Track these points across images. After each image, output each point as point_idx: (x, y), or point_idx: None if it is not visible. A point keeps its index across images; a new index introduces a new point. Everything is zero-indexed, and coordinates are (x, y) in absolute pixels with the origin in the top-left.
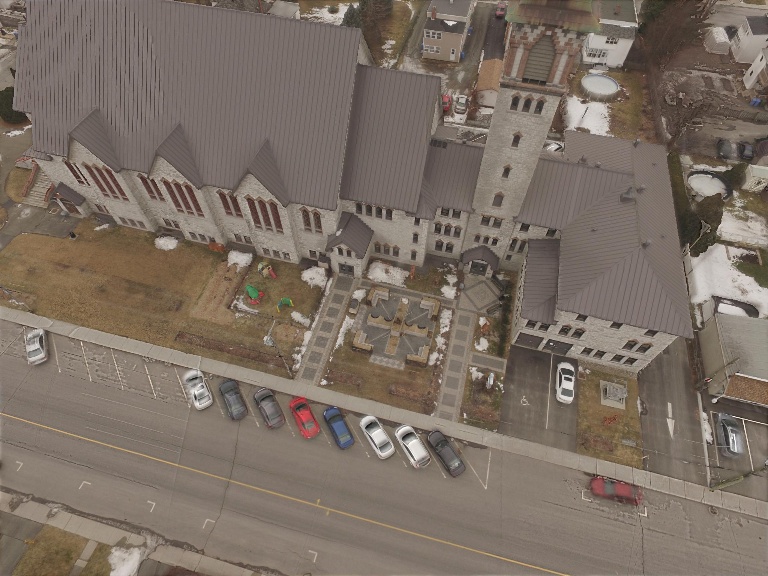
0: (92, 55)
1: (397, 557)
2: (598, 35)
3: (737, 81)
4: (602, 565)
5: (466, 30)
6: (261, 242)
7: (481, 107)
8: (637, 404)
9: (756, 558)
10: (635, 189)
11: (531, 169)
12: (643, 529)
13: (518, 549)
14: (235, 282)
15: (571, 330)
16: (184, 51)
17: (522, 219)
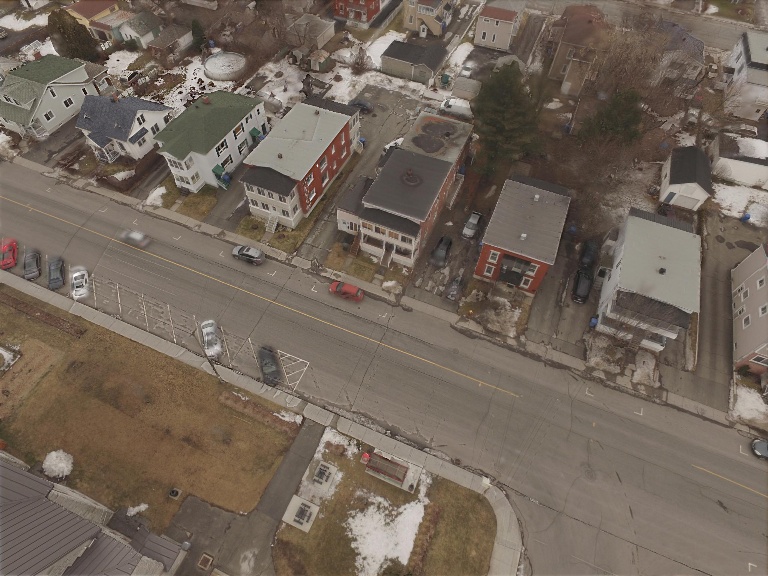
0: None
1: (2, 183)
2: None
3: None
4: None
5: None
6: None
7: None
8: None
9: None
10: None
11: None
12: None
13: None
14: None
15: None
16: None
17: None
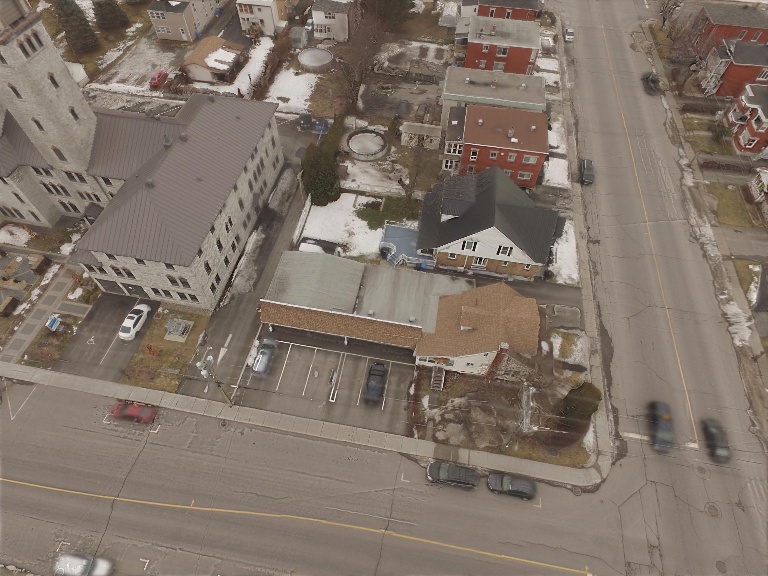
0: None
1: None
2: (315, 11)
3: (451, 50)
4: (88, 476)
5: (205, 11)
6: None
7: (194, 82)
8: (199, 337)
9: (239, 460)
10: (178, 137)
11: (52, 120)
12: (146, 443)
13: (14, 469)
14: None
15: (121, 271)
16: None
17: (93, 172)
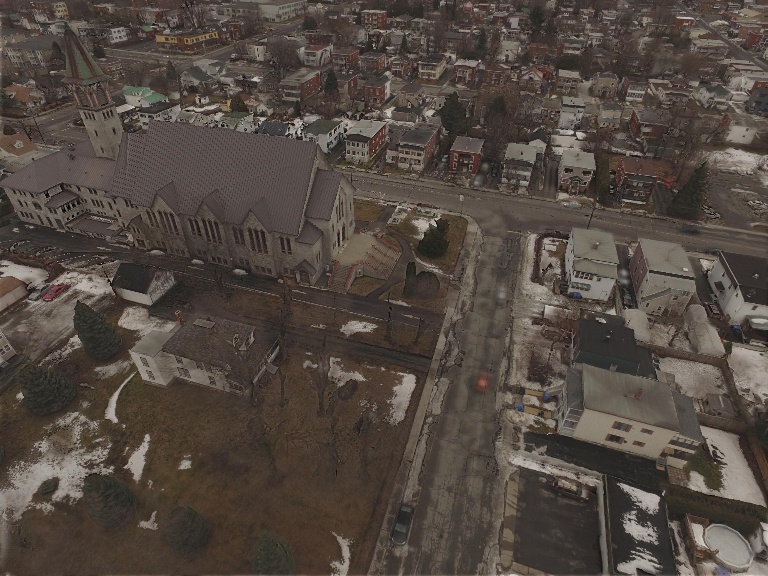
0: None
1: None
2: None
3: None
4: None
5: None
6: None
7: None
8: None
9: None
10: None
11: None
12: None
13: None
14: None
15: None
16: None
17: None
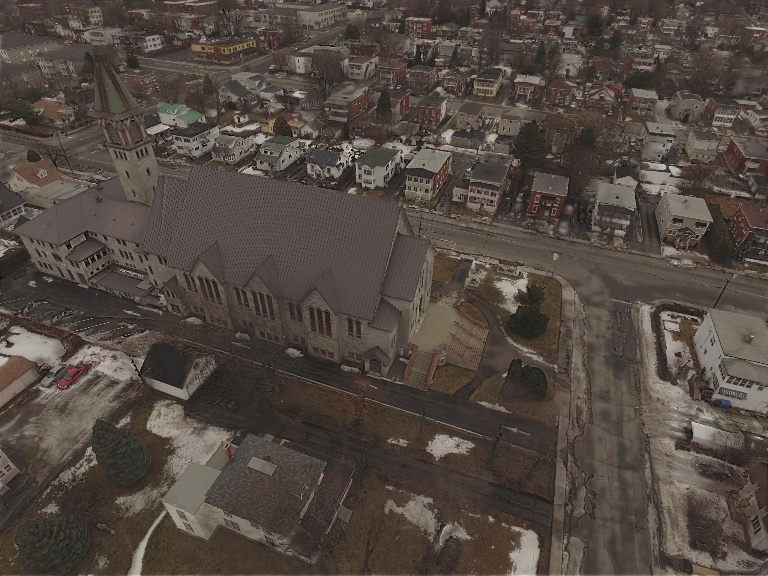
0: None
1: None
2: None
3: None
4: None
5: None
6: None
7: None
8: None
9: None
10: None
11: None
12: None
13: None
14: None
15: None
16: None
17: None
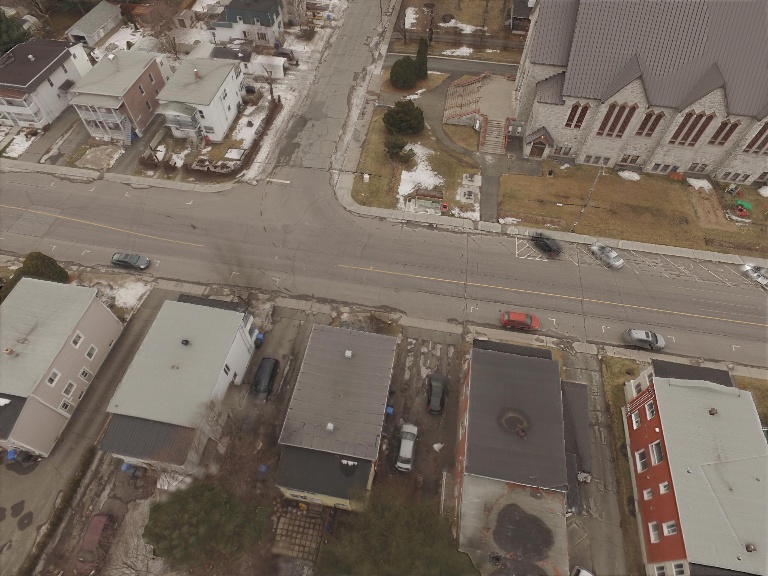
0: (644, 8)
1: None
2: None
3: None
4: None
5: None
6: (731, 166)
7: None
8: None
9: None
10: None
11: None
12: None
13: None
14: (714, 200)
15: None
16: (736, 1)
17: None
